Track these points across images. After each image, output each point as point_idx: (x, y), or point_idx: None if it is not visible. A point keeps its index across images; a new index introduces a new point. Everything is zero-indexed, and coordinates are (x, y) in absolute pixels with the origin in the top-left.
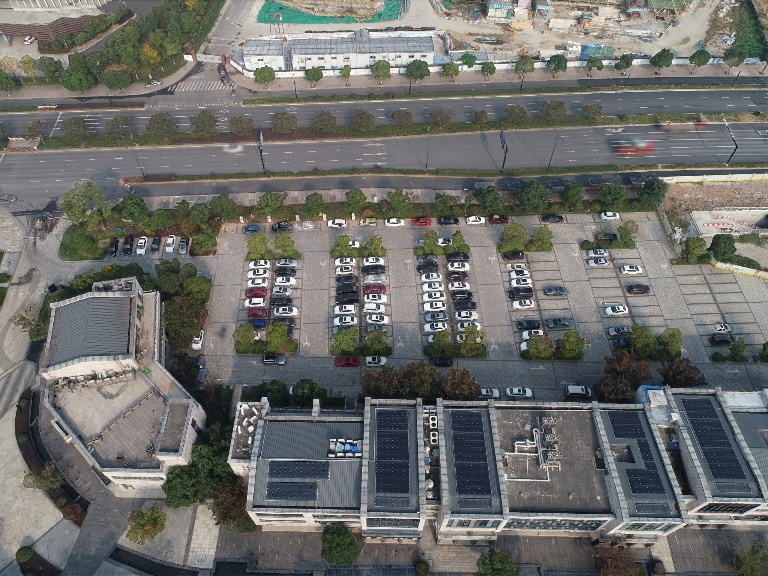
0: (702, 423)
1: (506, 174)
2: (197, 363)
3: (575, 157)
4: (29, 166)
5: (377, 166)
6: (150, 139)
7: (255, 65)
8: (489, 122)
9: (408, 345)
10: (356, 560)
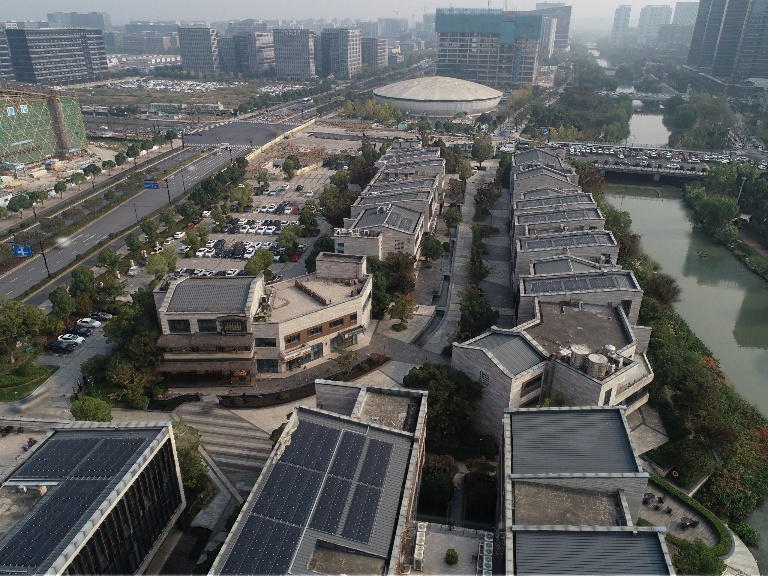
0: None
1: (174, 203)
2: None
3: (181, 188)
4: None
5: (110, 233)
6: None
7: None
8: (114, 201)
9: None
10: (438, 264)
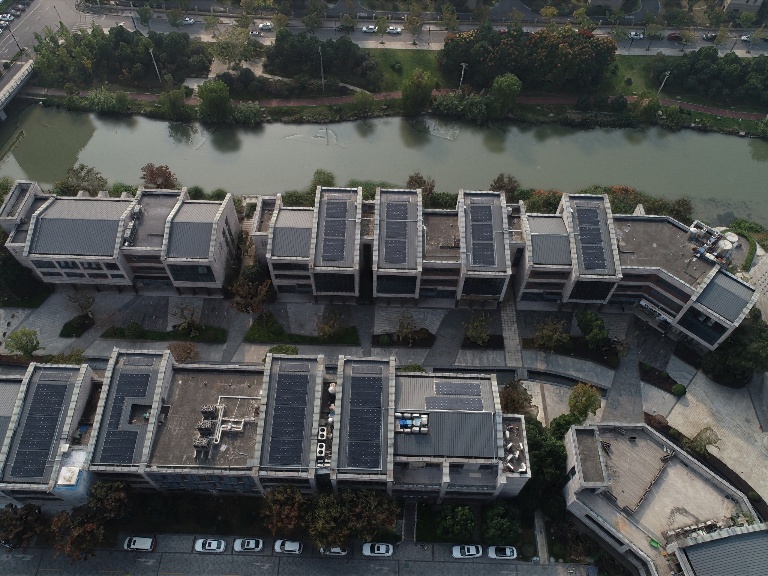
0: (40, 445)
1: None
2: None
3: None
4: None
5: None
6: None
7: None
8: None
9: None
10: None
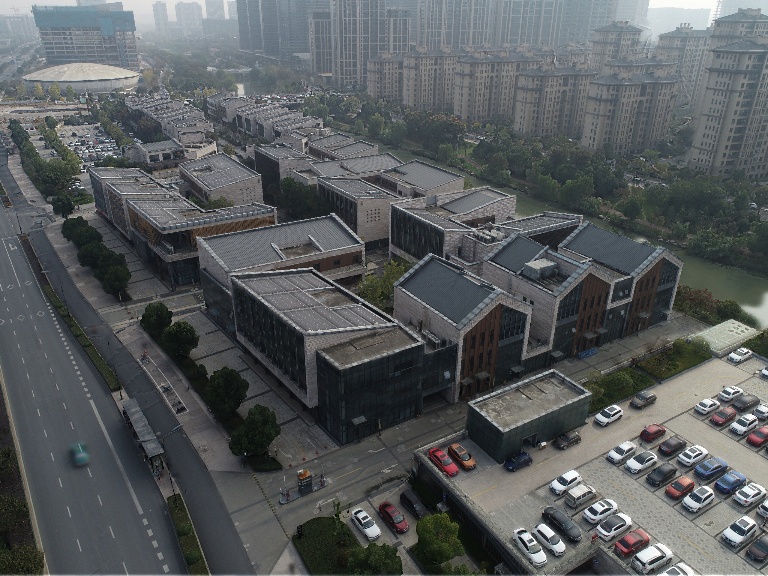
0: None
1: None
2: None
3: None
4: None
5: None
6: None
7: None
8: None
9: None
10: None
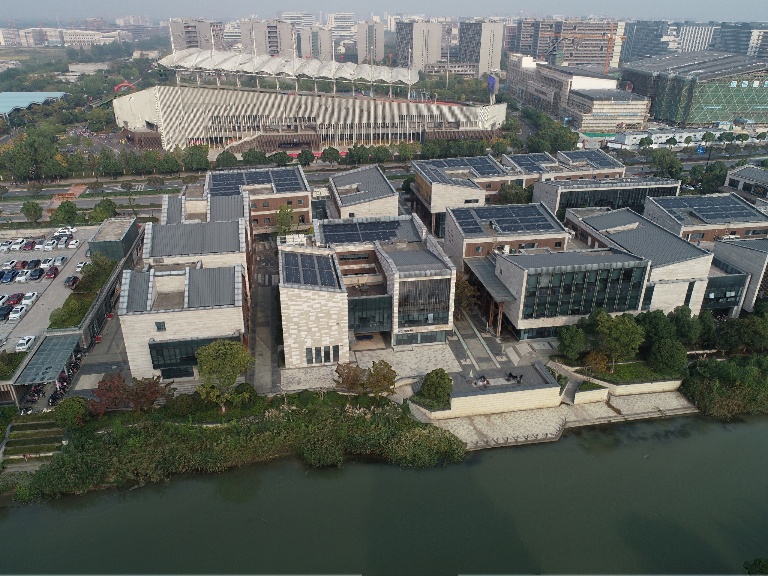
0: None
1: None
2: None
3: None
4: None
5: None
6: None
7: (630, 142)
8: None
9: None
10: None
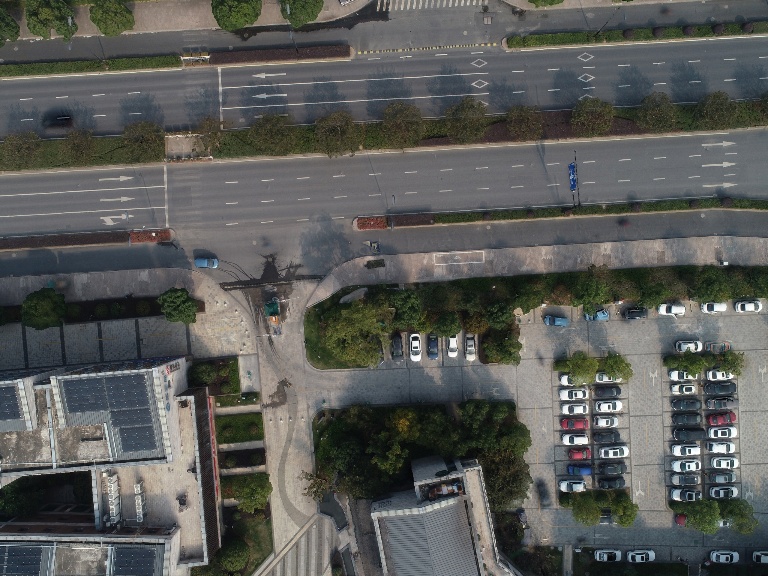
0: None
1: None
2: (520, 524)
3: None
4: (212, 193)
5: (729, 200)
6: (379, 137)
7: None
8: None
9: (759, 495)
10: None
